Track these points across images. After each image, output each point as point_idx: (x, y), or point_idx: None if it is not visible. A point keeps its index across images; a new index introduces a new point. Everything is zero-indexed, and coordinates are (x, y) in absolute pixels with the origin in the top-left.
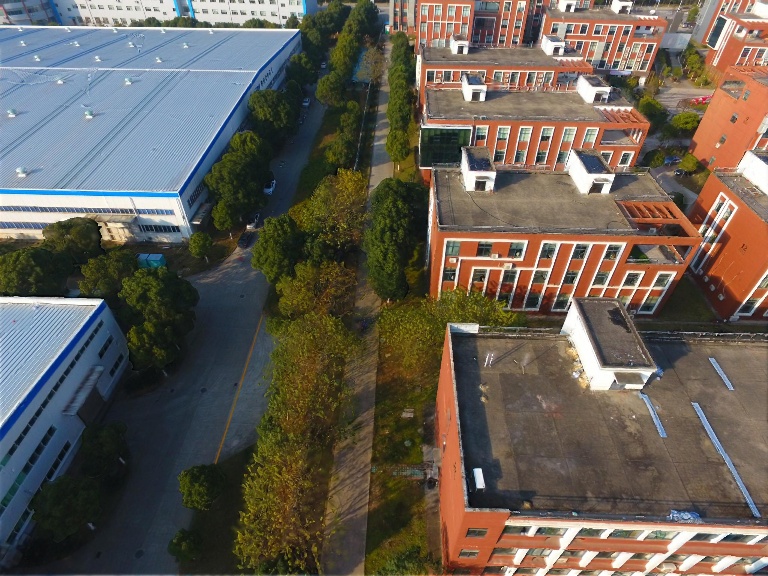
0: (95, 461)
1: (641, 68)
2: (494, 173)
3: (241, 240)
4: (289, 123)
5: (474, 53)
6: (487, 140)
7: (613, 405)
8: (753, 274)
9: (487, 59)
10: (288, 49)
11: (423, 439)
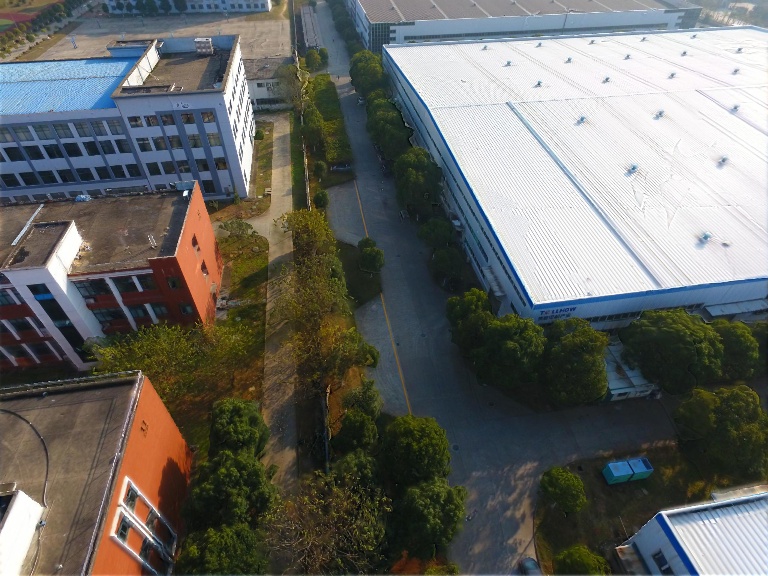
0: None
1: None
2: None
3: (535, 568)
4: None
5: None
6: None
7: None
8: None
9: None
10: None
11: (225, 322)
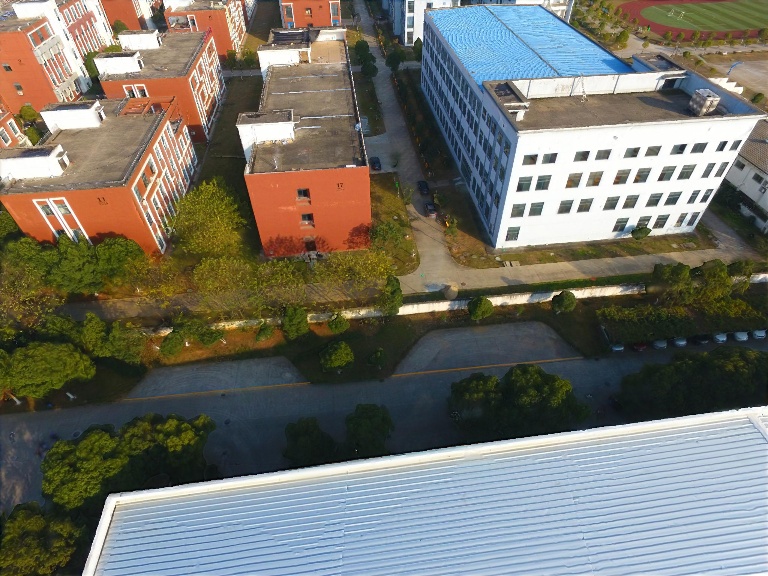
0: (325, 437)
1: None
2: (60, 146)
3: None
4: None
5: None
6: None
7: (303, 136)
8: (194, 106)
9: None
10: None
11: None
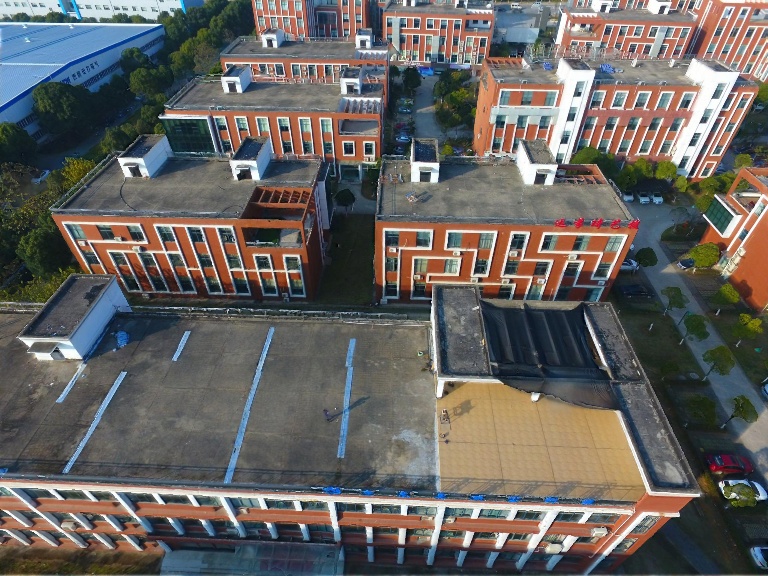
0: None
1: (479, 62)
2: (141, 160)
3: None
4: (74, 115)
5: (286, 46)
6: (230, 130)
7: (44, 373)
8: None
9: (291, 52)
10: (136, 44)
11: None
